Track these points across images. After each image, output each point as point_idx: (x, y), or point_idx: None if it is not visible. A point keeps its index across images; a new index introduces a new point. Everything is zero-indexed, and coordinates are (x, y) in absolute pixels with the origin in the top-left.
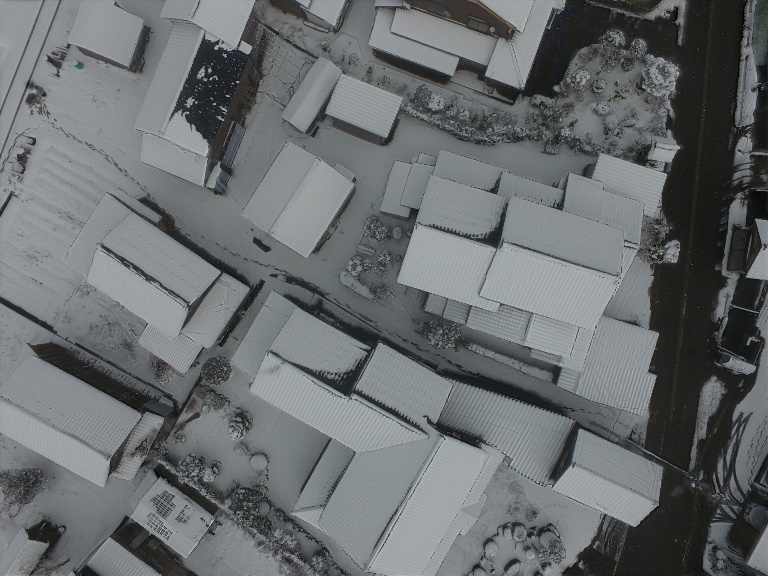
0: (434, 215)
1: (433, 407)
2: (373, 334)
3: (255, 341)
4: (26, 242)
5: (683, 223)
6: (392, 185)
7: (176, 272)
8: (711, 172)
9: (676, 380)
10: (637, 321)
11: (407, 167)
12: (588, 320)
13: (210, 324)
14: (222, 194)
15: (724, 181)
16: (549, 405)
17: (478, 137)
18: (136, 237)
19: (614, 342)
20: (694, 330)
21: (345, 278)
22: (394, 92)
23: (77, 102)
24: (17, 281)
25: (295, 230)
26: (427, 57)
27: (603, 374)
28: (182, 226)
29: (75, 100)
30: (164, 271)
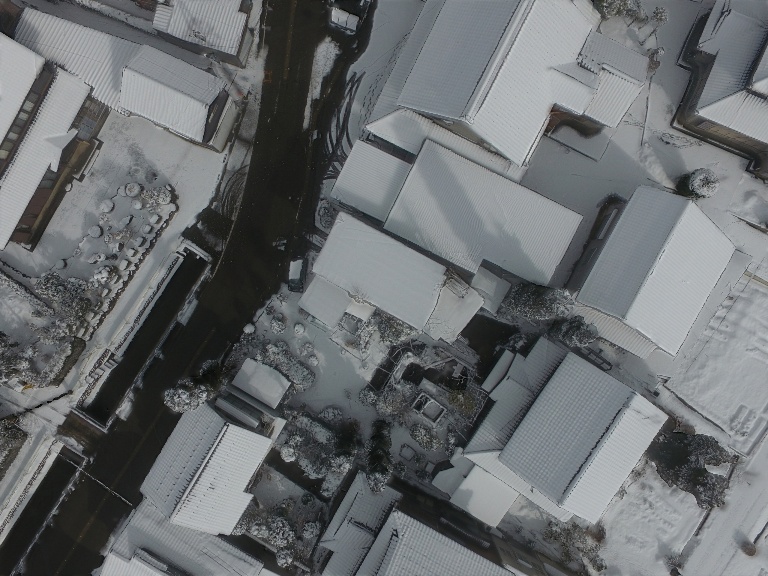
0: None
1: None
2: None
3: None
4: None
5: None
6: None
7: None
8: None
9: (290, 40)
10: None
11: None
12: None
13: None
14: None
15: None
16: None
17: None
18: None
19: None
20: None
21: None
22: None
23: None
24: None
25: None
26: None
27: (194, 13)
28: None
29: None
30: None
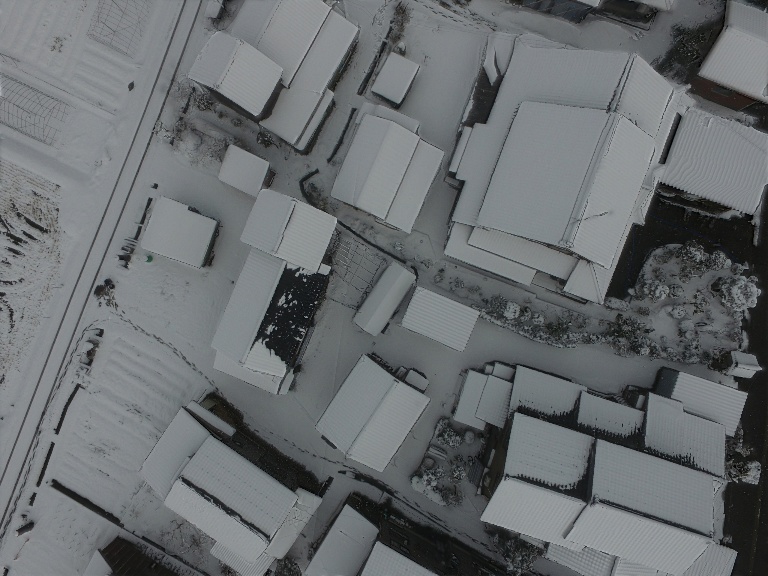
0: (522, 463)
1: None
2: (443, 534)
3: (334, 571)
4: (93, 434)
5: (758, 427)
6: (467, 395)
7: (255, 502)
8: None
9: None
10: None
11: (482, 379)
12: (676, 568)
13: (283, 537)
14: (291, 389)
15: None
16: None
17: (553, 344)
18: (215, 465)
19: None
20: None
21: (417, 485)
22: (466, 291)
23: (146, 295)
24: (84, 473)
25: (371, 449)
26: (503, 267)
27: None
28: (251, 422)
29: (144, 292)
30: (244, 502)
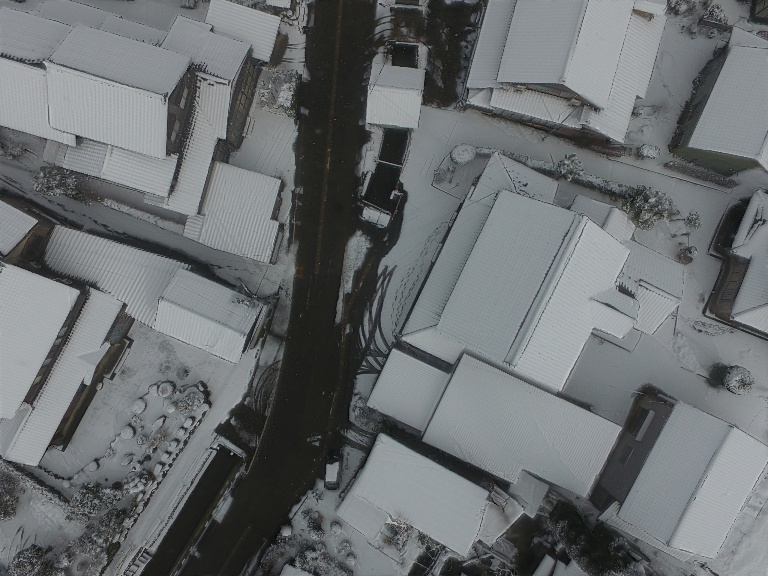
0: None
1: (7, 240)
2: (17, 195)
3: None
4: None
5: (326, 78)
6: None
7: None
8: (353, 26)
9: (321, 235)
10: (282, 177)
11: None
12: (156, 148)
13: None
14: None
15: (367, 35)
16: (194, 262)
17: None
18: None
19: (236, 190)
20: (338, 185)
21: None
22: None
23: None
24: None
25: None
26: None
27: (226, 222)
28: None
29: None
30: None
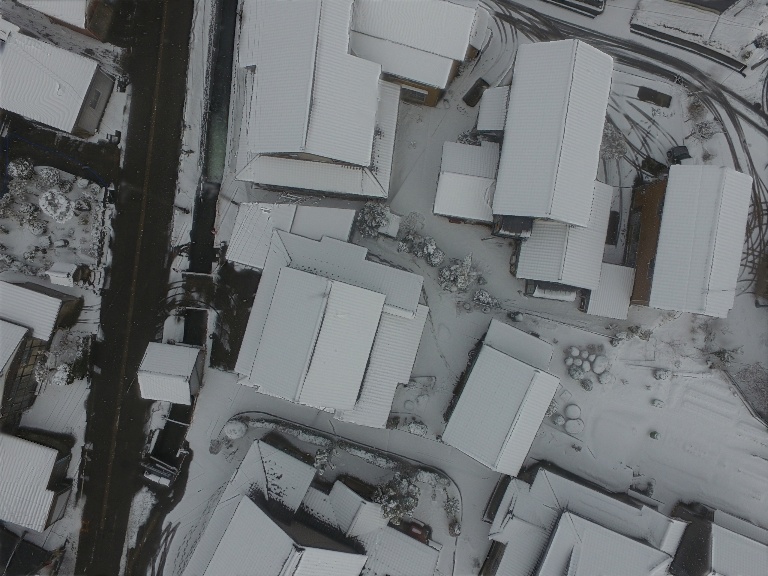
0: None
1: None
2: None
3: None
4: None
5: (119, 338)
6: None
7: None
8: (147, 289)
9: (108, 491)
10: (73, 433)
11: None
12: None
13: None
14: None
15: (160, 298)
16: None
17: None
18: None
19: (15, 460)
20: (126, 442)
21: None
22: None
23: None
24: None
25: None
26: None
27: (3, 491)
28: None
29: None
30: None
